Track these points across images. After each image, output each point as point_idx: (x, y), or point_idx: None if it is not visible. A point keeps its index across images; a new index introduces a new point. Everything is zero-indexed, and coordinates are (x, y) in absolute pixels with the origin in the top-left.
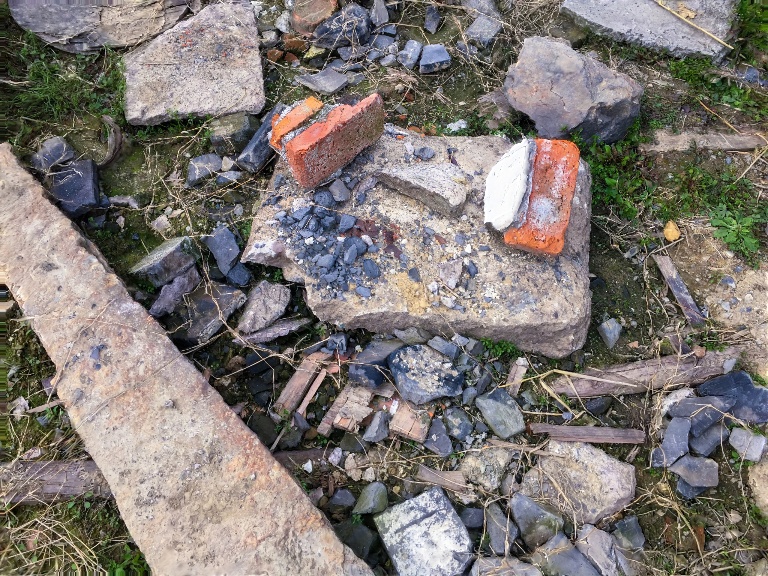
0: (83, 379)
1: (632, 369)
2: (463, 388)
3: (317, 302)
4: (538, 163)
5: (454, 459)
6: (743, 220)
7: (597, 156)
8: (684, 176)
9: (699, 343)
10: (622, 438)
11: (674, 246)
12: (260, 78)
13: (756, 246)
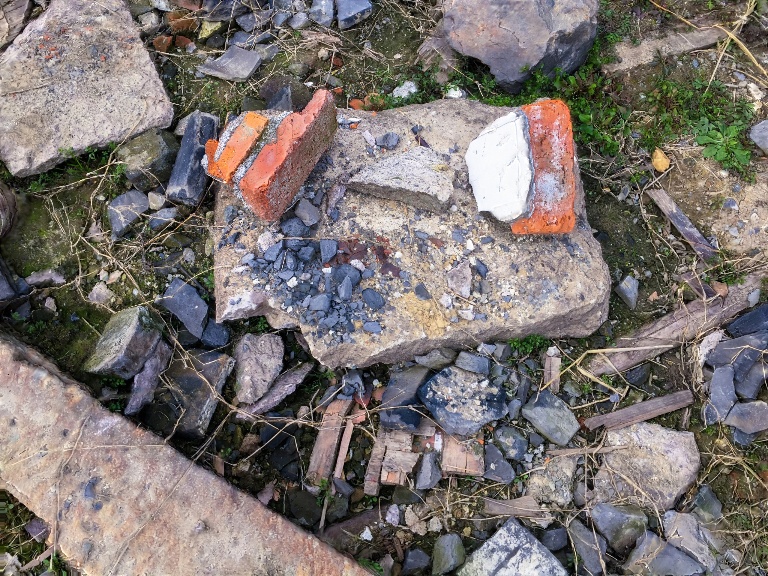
0: (87, 525)
1: (663, 328)
2: (505, 402)
3: (323, 351)
4: (532, 137)
5: (519, 483)
6: (727, 131)
7: (562, 90)
8: (658, 94)
9: (717, 278)
10: (673, 405)
11: (666, 176)
12: (157, 79)
13: (747, 158)
